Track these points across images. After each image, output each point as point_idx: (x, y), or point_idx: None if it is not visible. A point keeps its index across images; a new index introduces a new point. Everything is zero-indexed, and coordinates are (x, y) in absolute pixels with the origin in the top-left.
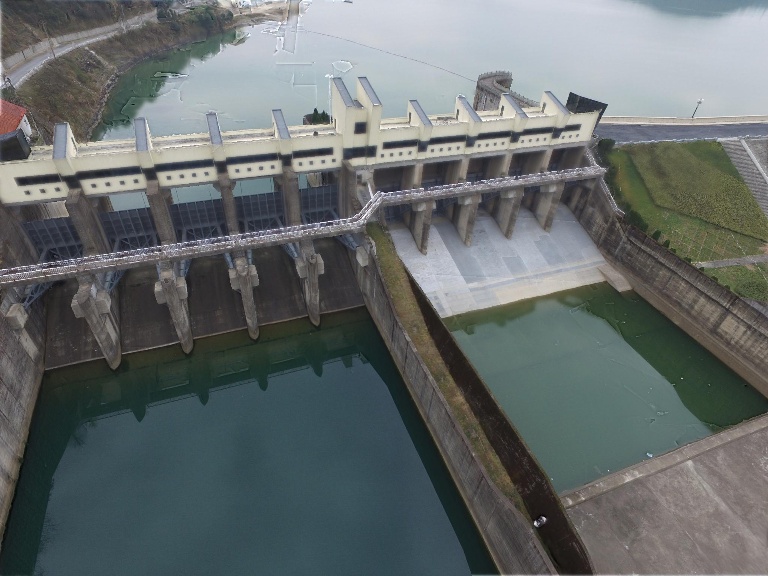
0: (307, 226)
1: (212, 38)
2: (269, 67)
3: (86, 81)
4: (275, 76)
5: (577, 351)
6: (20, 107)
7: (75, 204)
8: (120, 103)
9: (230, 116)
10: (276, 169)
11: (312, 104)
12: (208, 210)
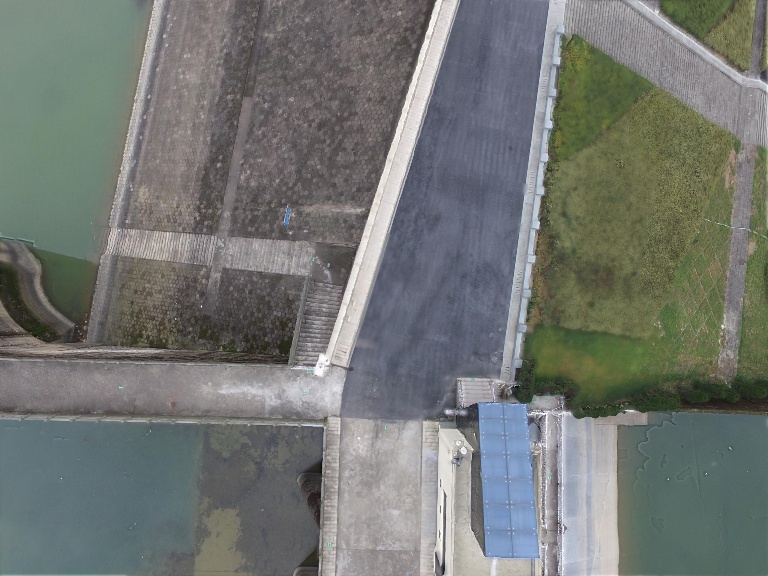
0: None
1: None
2: None
3: None
4: None
5: (723, 575)
6: None
7: None
8: None
9: None
10: None
11: None
12: None
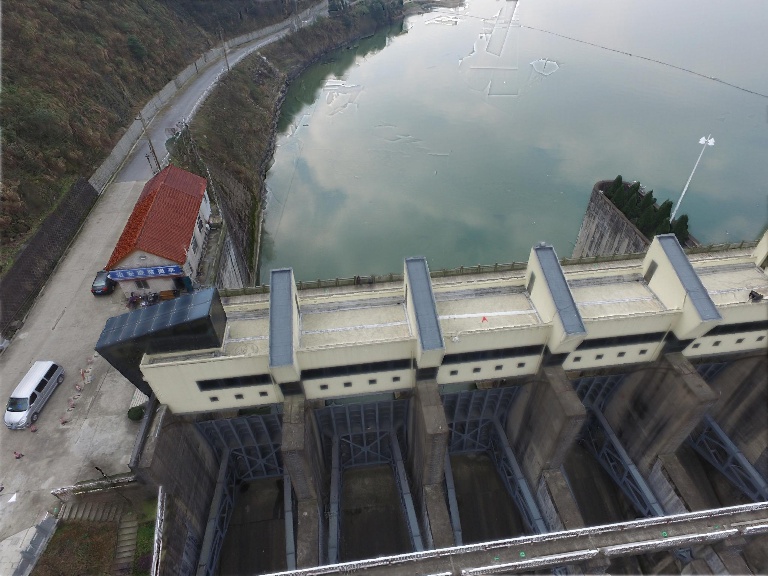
0: (734, 508)
1: (380, 31)
2: (460, 72)
3: (259, 98)
4: (466, 83)
5: None
6: (200, 177)
7: (299, 450)
8: (285, 115)
9: (425, 146)
10: (647, 354)
11: (507, 119)
12: (488, 398)
